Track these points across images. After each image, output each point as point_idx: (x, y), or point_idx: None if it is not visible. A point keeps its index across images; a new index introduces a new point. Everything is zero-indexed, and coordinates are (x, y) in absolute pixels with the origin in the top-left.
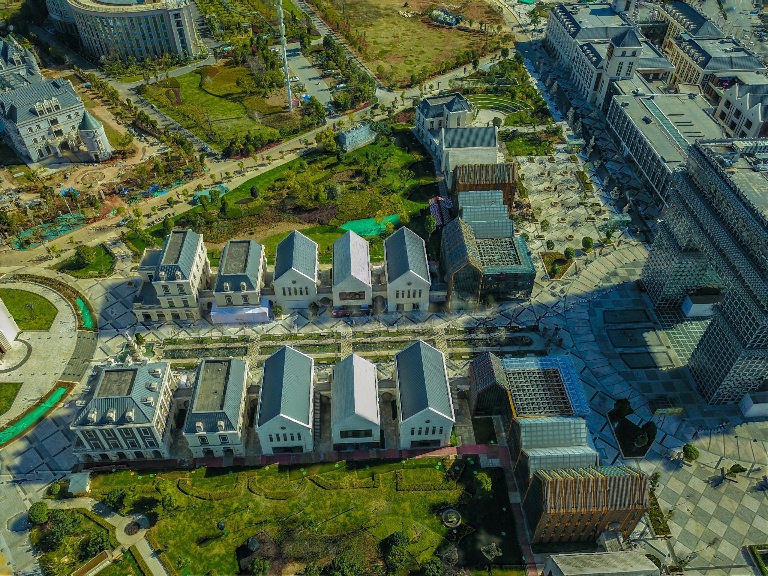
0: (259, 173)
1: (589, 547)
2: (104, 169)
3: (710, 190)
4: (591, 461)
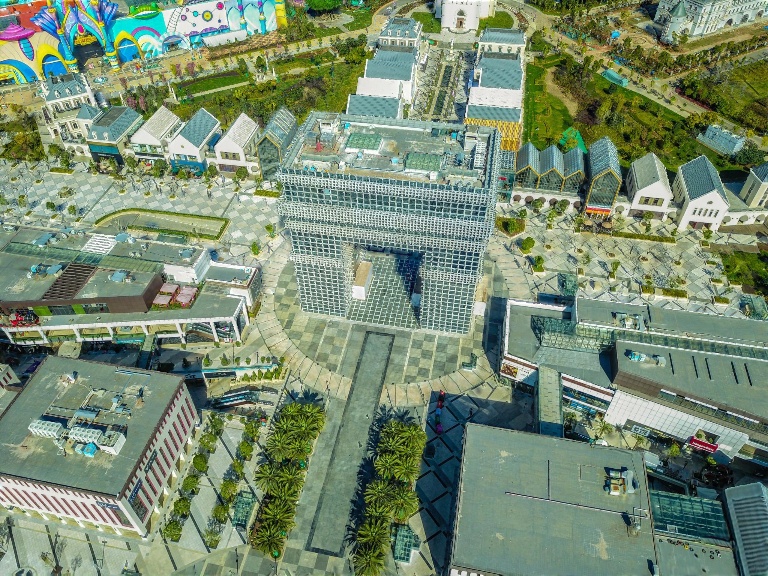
0: (653, 99)
1: None
2: (650, 43)
3: None
4: None
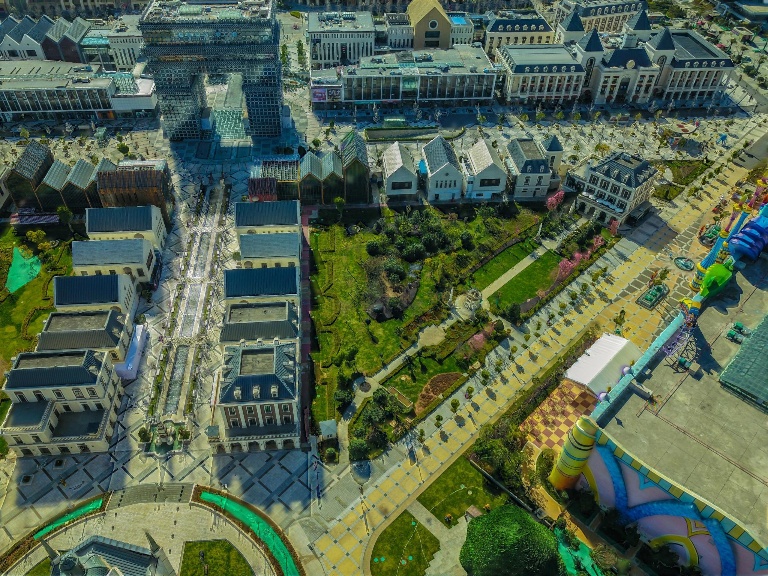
0: None
1: (370, 184)
2: None
3: (180, 37)
4: (335, 155)
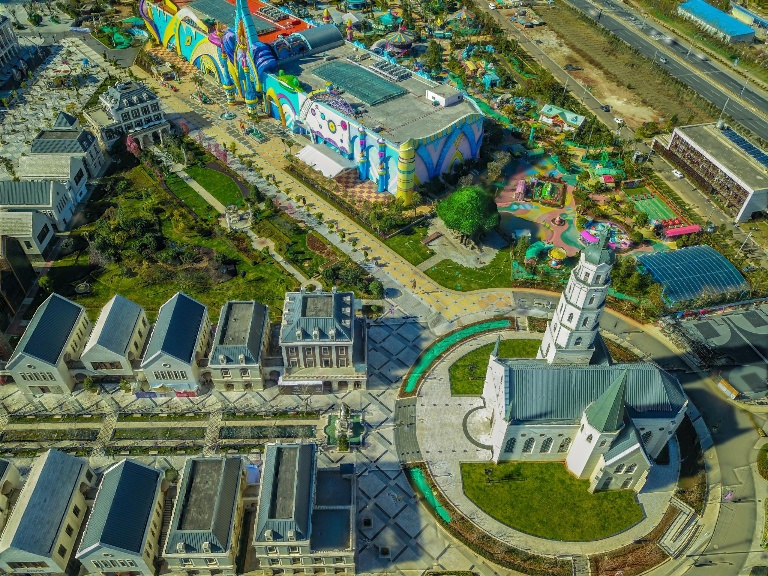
0: None
1: None
2: None
3: None
4: None
